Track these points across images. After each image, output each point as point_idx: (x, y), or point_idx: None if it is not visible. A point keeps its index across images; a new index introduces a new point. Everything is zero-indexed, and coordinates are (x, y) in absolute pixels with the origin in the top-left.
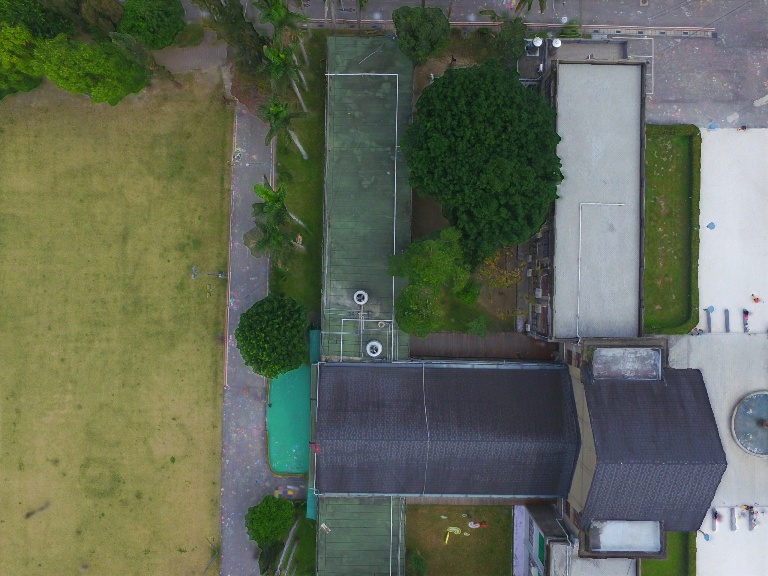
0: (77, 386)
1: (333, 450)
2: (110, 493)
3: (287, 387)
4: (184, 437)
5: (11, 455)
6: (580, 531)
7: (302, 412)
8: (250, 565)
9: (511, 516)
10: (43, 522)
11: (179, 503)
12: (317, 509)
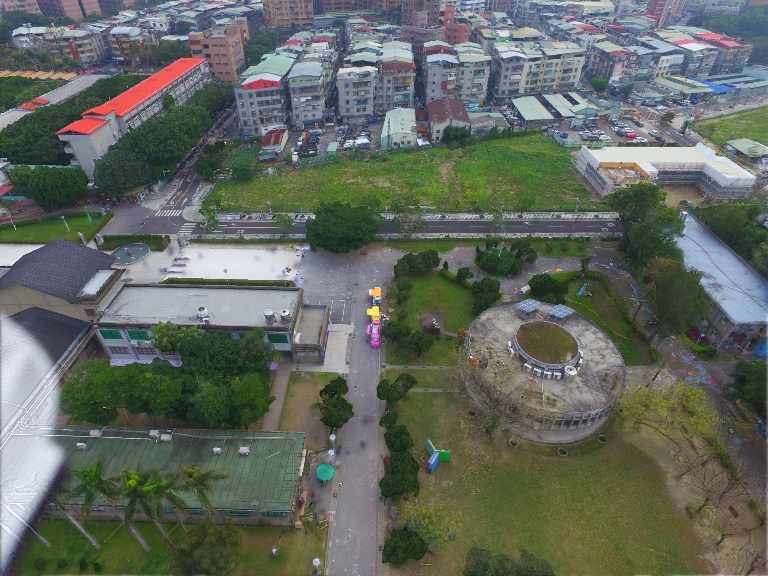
0: None
1: None
2: None
3: None
4: None
5: None
6: (81, 303)
7: None
8: None
9: (114, 368)
10: None
11: None
12: None
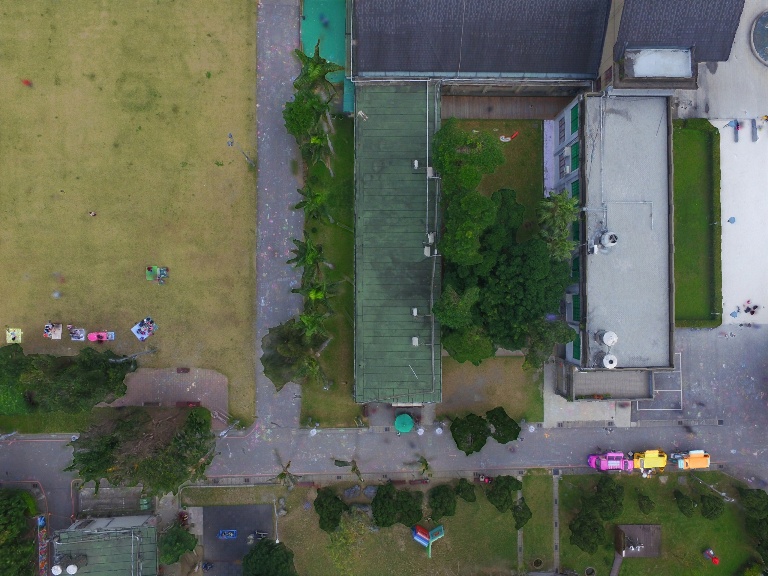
0: (112, 2)
1: (372, 9)
2: (147, 107)
3: (320, 0)
4: (219, 53)
5: (47, 70)
6: (614, 63)
7: (335, 24)
8: (286, 179)
9: (541, 131)
10: (80, 136)
11: (215, 117)
12: (354, 97)
